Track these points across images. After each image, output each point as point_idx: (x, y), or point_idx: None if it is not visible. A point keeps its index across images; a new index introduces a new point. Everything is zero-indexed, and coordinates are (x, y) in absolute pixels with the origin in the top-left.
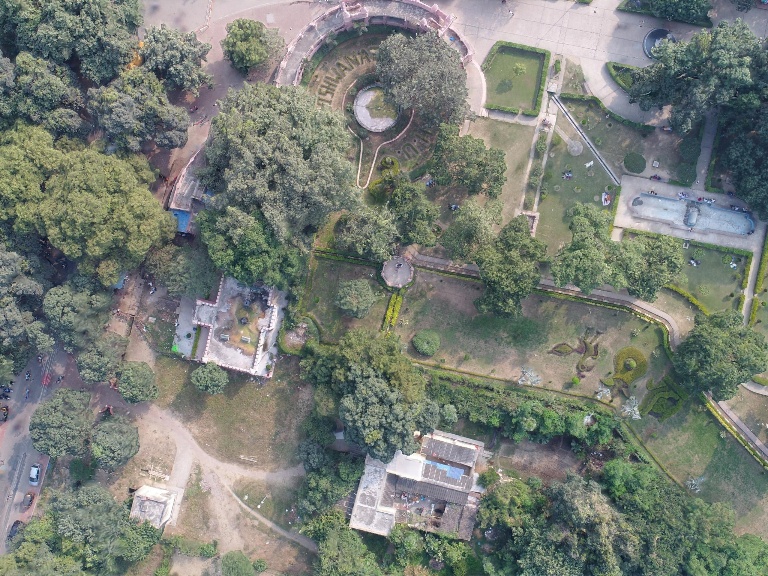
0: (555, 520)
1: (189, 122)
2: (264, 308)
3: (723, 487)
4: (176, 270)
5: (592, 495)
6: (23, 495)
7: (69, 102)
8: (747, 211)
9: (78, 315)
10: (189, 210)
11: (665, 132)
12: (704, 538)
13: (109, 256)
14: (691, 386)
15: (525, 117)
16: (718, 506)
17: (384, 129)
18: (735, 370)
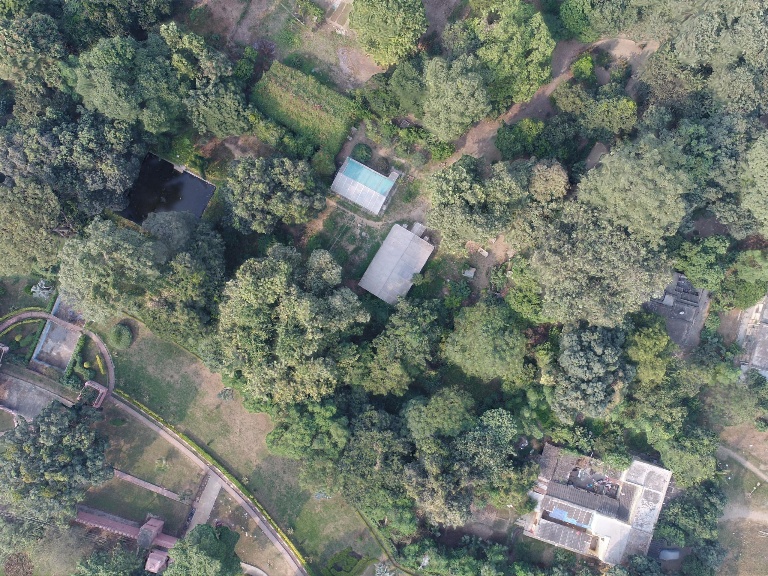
0: None
1: None
2: None
3: (294, 479)
4: None
5: None
6: None
7: None
8: None
9: None
10: None
11: None
12: None
13: None
14: None
15: None
16: None
17: None
18: None
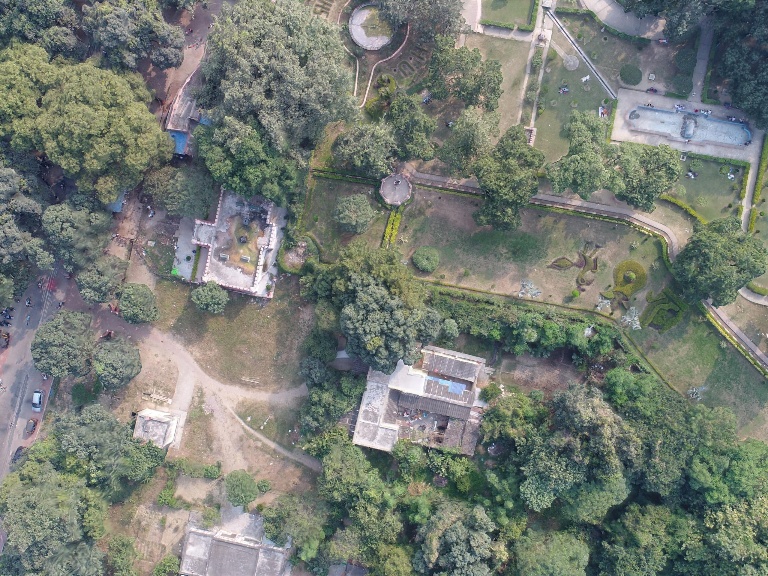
0: (557, 428)
1: (184, 44)
2: (263, 227)
3: (724, 397)
4: (174, 188)
5: (594, 399)
6: (26, 421)
7: (64, 22)
8: (744, 121)
9: (77, 232)
10: (186, 131)
11: (661, 45)
12: (706, 441)
13: (107, 173)
14: (691, 293)
15: (520, 33)
16: (720, 410)
17: (380, 47)
18: (734, 271)
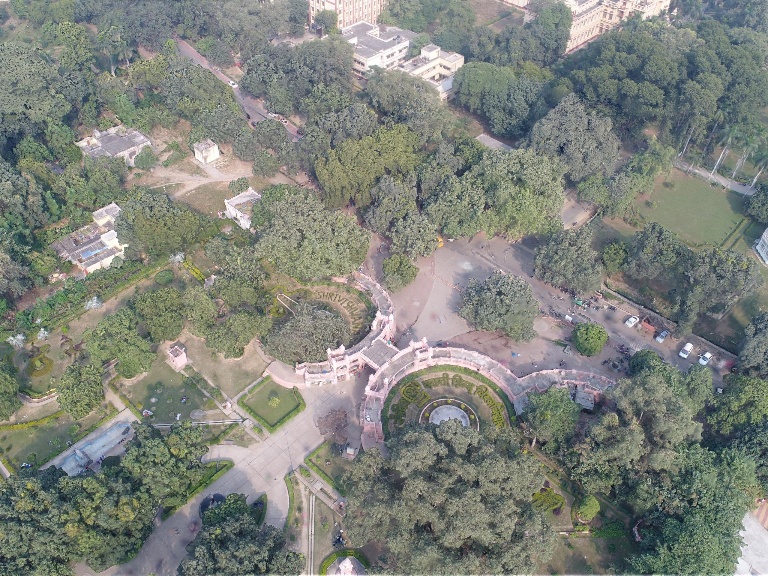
0: None
1: None
2: None
3: None
4: None
5: (2, 270)
6: None
7: None
8: None
9: None
10: None
11: None
12: None
13: None
14: None
15: None
16: None
17: None
18: None
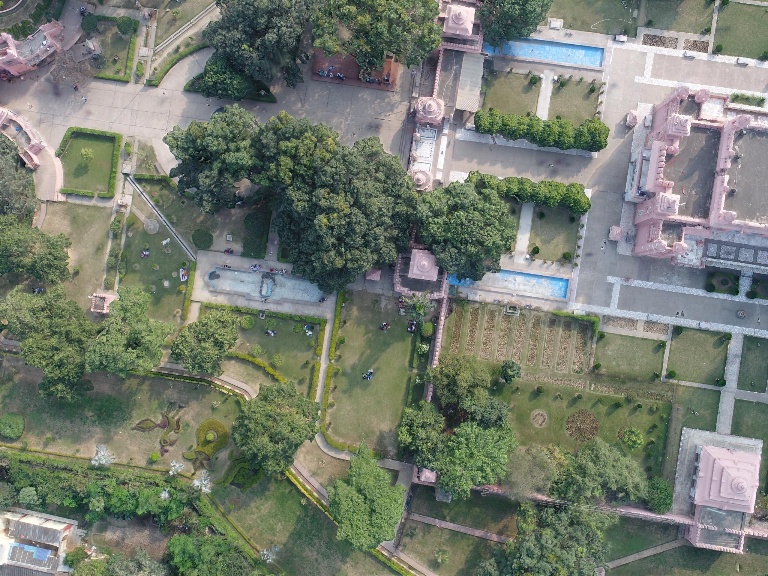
0: None
1: None
2: None
3: (307, 554)
4: None
5: (134, 575)
6: None
7: None
8: None
9: None
10: None
11: (237, 206)
12: None
13: None
14: None
15: (101, 199)
16: None
17: None
18: (265, 445)
